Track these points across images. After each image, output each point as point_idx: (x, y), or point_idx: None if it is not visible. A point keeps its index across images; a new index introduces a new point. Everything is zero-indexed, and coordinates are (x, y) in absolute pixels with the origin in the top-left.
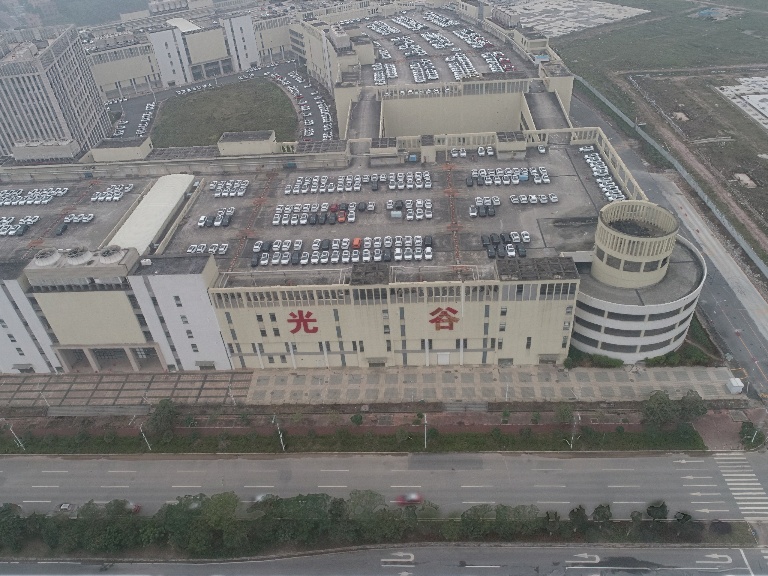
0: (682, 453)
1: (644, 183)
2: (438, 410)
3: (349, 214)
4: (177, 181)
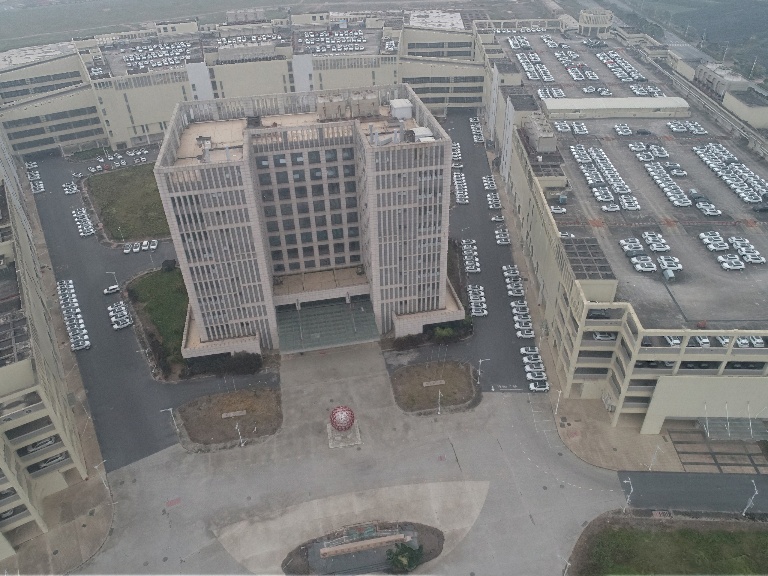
0: None
1: None
2: None
3: None
4: (558, 100)
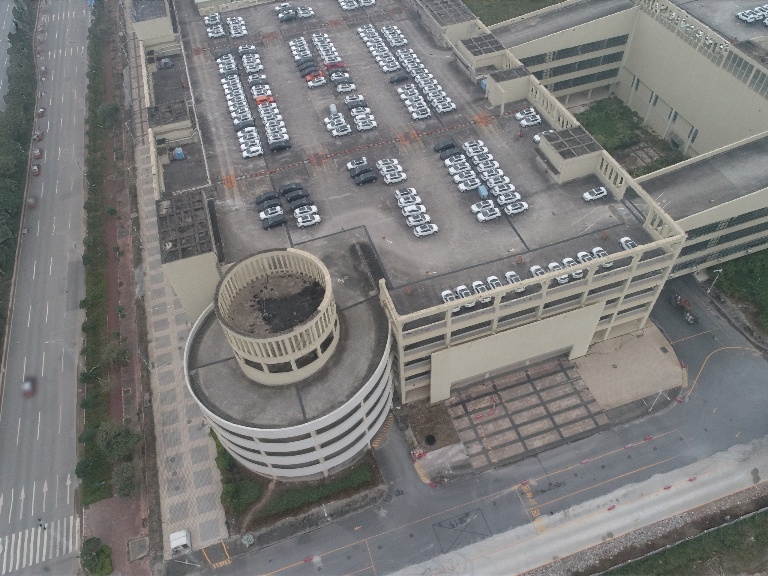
0: (80, 481)
1: (763, 411)
2: (134, 263)
3: (316, 78)
4: None
